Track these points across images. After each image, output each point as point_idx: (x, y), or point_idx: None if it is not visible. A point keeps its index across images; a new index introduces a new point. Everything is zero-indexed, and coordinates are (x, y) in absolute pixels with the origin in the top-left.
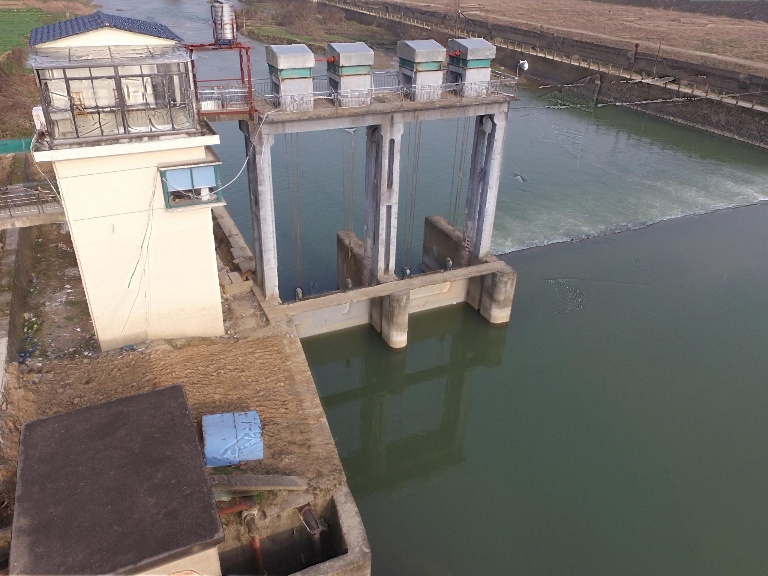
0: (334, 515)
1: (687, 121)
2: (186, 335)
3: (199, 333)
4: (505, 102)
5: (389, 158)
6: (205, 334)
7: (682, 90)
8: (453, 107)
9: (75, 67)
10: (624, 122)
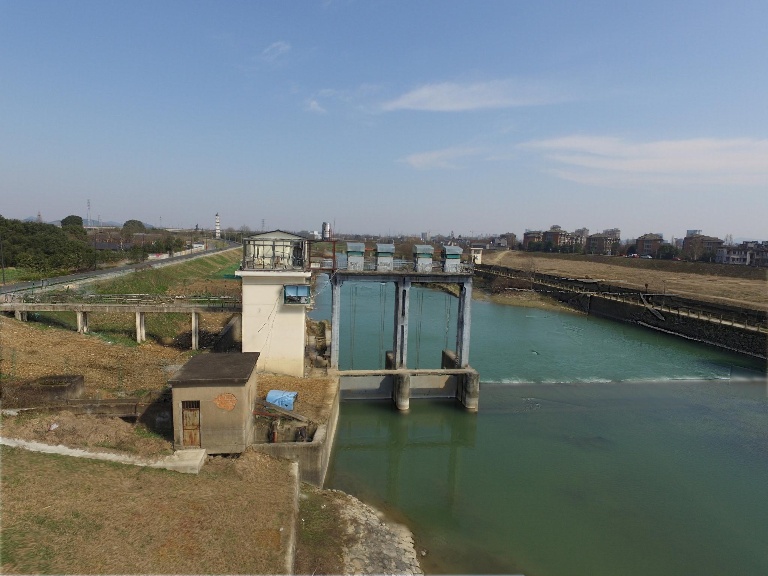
0: None
1: (687, 335)
2: (283, 373)
3: (290, 373)
4: (470, 277)
5: (403, 300)
6: (293, 374)
7: (681, 314)
8: (439, 277)
9: (258, 240)
10: (644, 337)
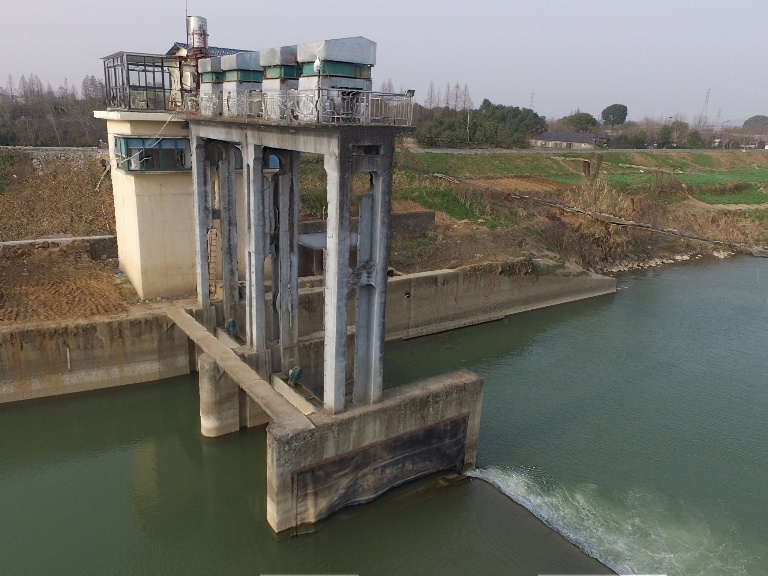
0: None
1: None
2: None
3: None
4: (335, 137)
5: None
6: None
7: None
8: None
9: None
10: None
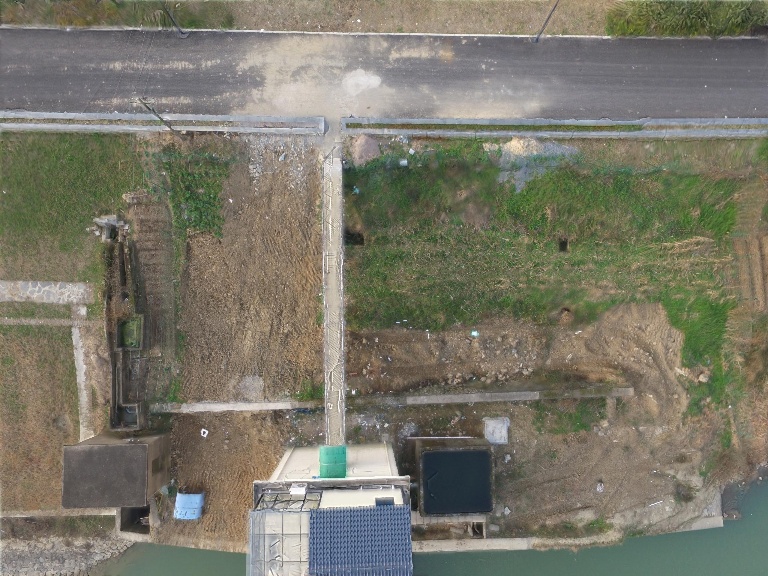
0: (147, 530)
1: None
2: None
3: None
4: None
5: None
6: None
7: None
8: None
9: None
10: None
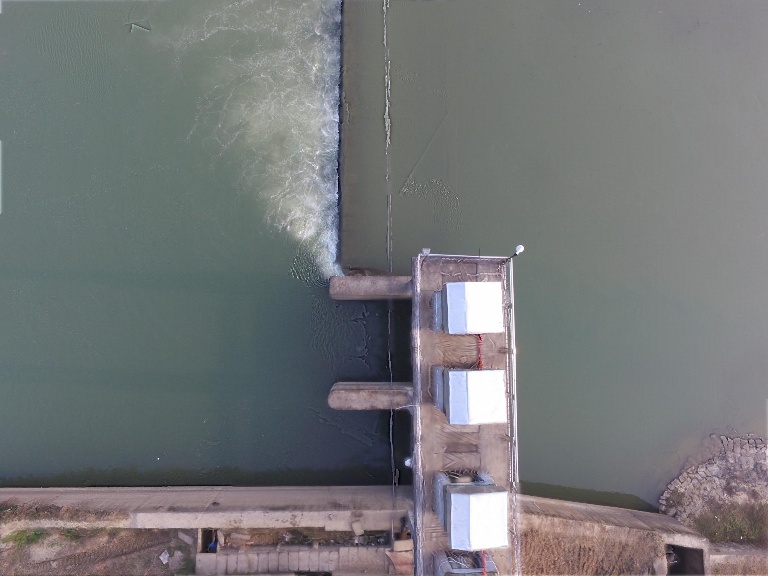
0: None
1: None
2: None
3: None
4: None
5: None
6: None
7: None
8: None
9: None
10: None
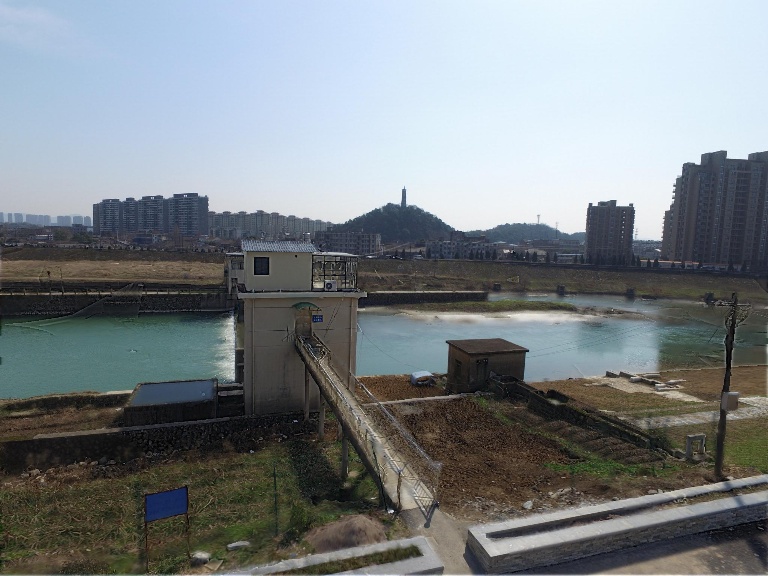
0: None
1: None
2: None
3: None
4: None
5: None
6: None
7: (102, 294)
8: None
9: None
10: None
